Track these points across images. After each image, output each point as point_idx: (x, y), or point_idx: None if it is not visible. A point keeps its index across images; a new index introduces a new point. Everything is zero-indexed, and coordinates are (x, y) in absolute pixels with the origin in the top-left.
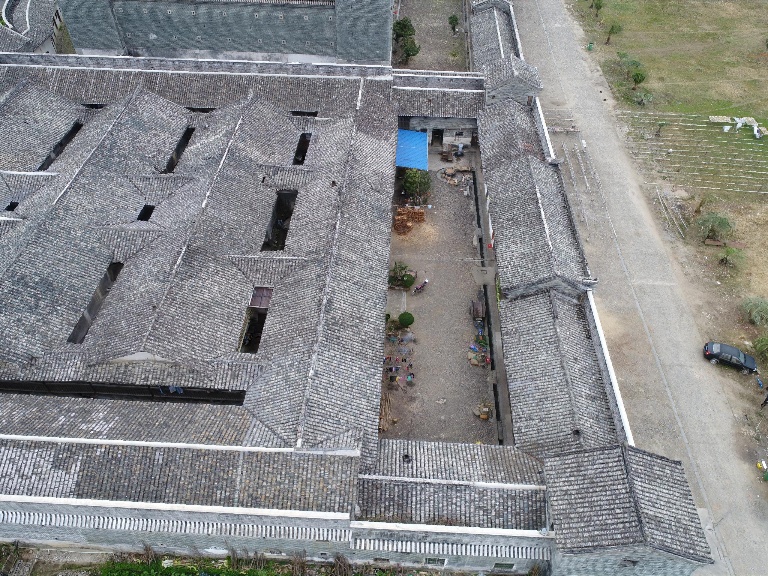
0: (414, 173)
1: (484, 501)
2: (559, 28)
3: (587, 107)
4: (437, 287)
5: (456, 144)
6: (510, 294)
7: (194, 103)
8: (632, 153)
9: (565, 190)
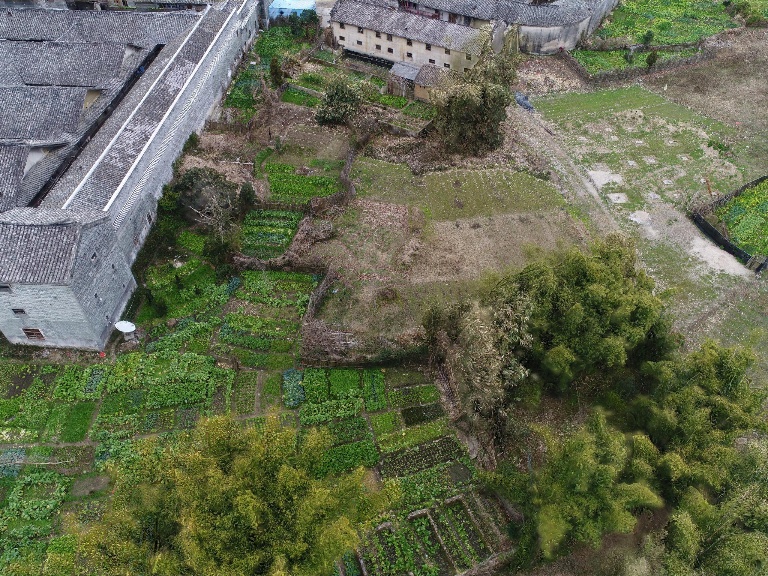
0: None
1: (236, 1)
2: None
3: None
4: None
5: None
6: None
7: None
8: None
9: None
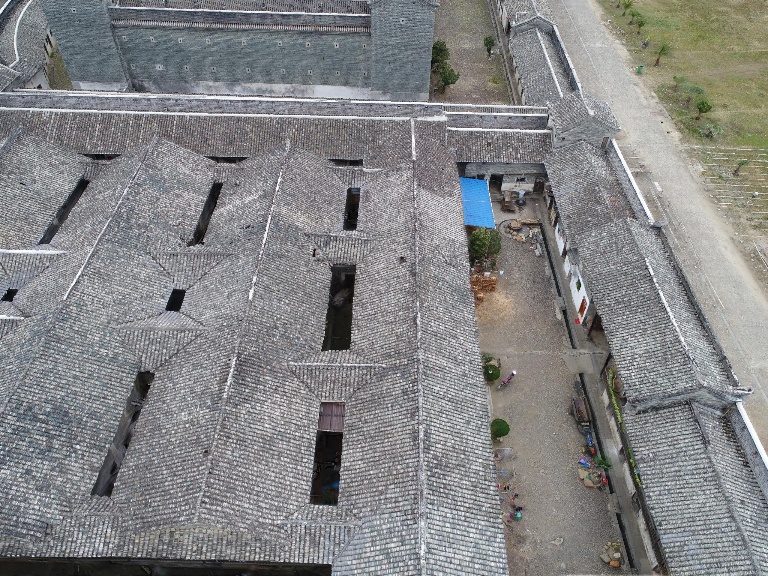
0: (483, 234)
1: None
2: (601, 48)
3: (651, 141)
4: (525, 378)
5: (516, 190)
6: (639, 406)
7: (218, 151)
8: (713, 197)
9: (678, 262)
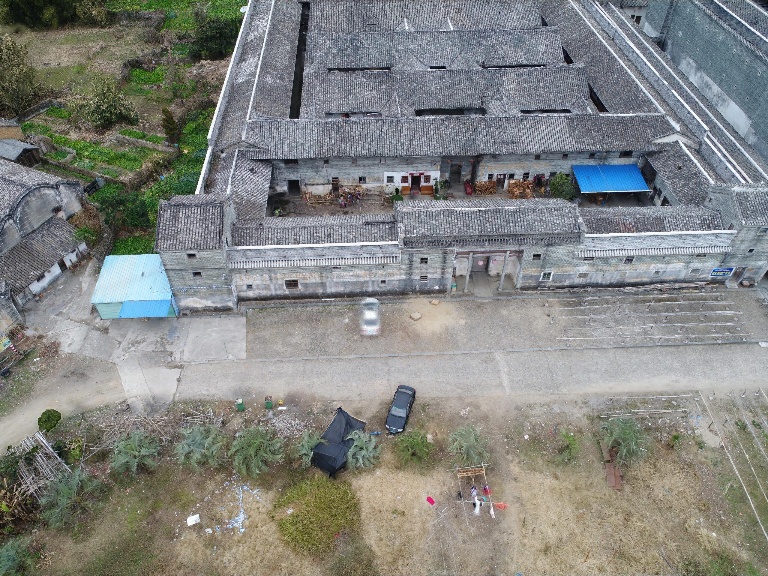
0: (561, 177)
1: None
2: None
3: None
4: None
5: None
6: None
7: None
8: None
9: None
